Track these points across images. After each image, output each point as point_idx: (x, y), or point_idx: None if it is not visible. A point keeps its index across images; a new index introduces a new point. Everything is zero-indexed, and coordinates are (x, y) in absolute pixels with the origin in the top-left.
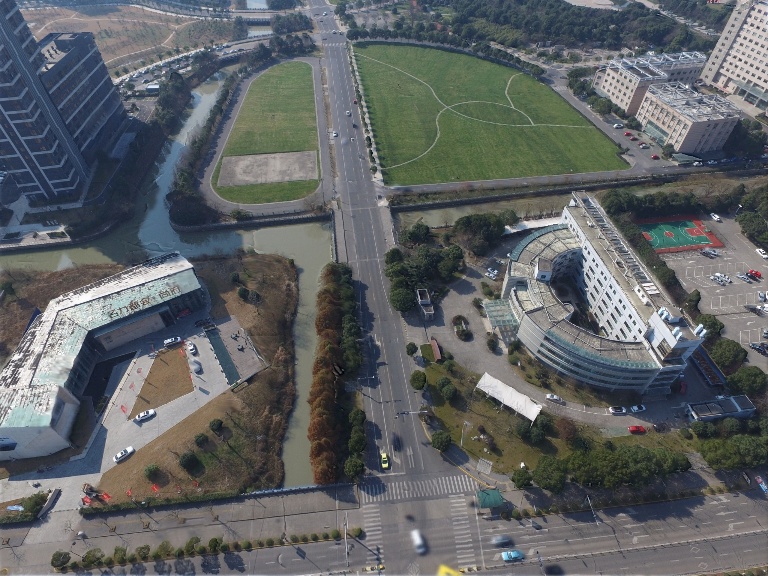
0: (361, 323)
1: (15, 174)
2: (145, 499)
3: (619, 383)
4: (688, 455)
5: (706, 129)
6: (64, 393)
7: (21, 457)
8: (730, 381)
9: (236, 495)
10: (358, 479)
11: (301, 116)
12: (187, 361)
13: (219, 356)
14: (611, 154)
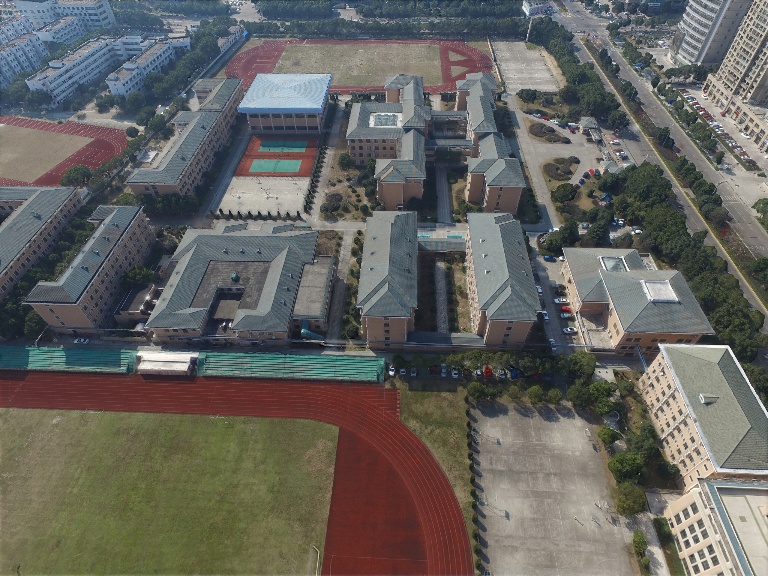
0: None
1: None
2: None
3: None
4: None
5: None
6: None
7: None
8: None
9: None
10: None
11: None
12: None
13: None
14: None
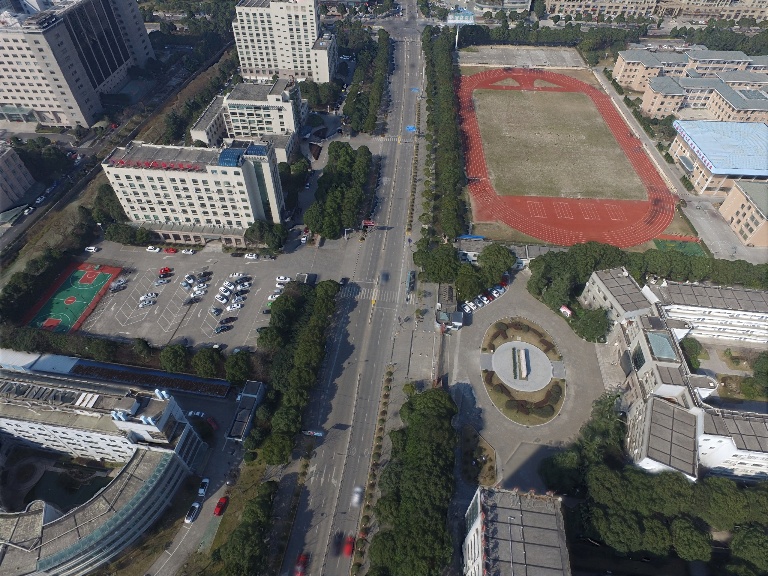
0: None
1: None
2: None
3: (165, 497)
4: (267, 471)
5: None
6: None
7: None
8: (230, 381)
9: None
10: None
11: None
12: None
13: None
14: None
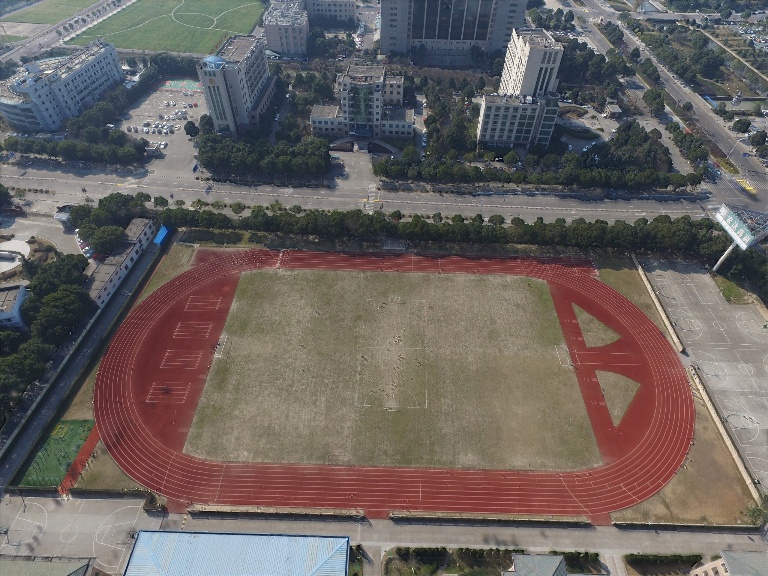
0: None
1: None
2: None
3: (15, 119)
4: None
5: (280, 32)
6: None
7: None
8: None
9: None
10: None
11: (74, 9)
12: None
13: None
14: None
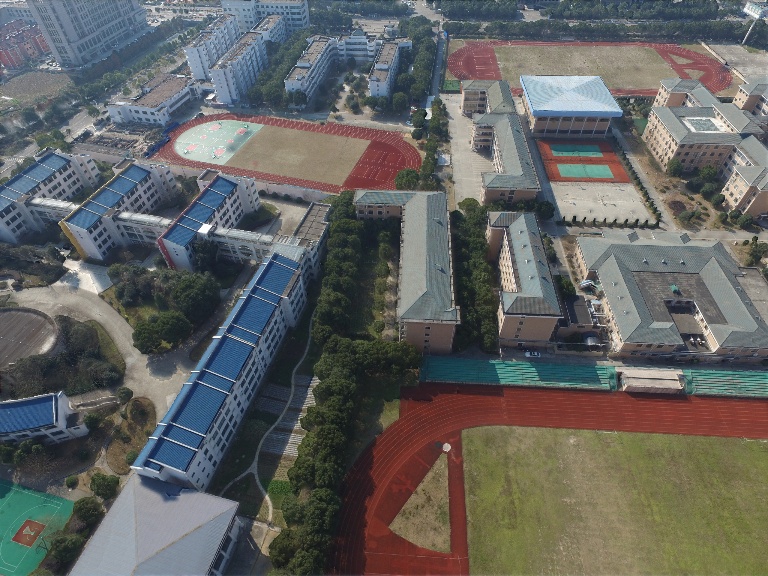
0: None
1: None
2: None
3: None
4: None
5: None
6: None
7: None
8: None
9: (204, 5)
10: None
11: None
12: None
13: None
14: None
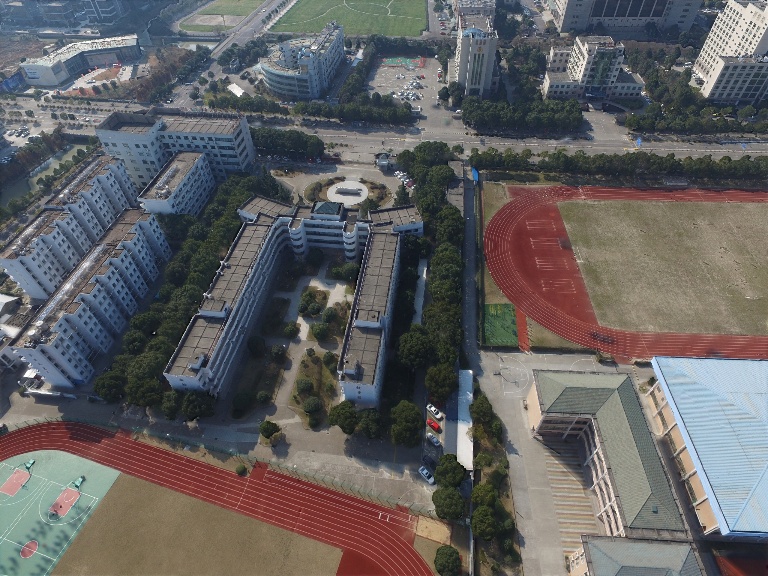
0: (201, 70)
1: (84, 2)
2: (75, 95)
3: (286, 89)
4: None
5: None
6: (62, 65)
7: (41, 84)
8: None
9: (107, 99)
10: (155, 104)
11: (254, 2)
12: (119, 72)
13: (133, 72)
14: (418, 30)
